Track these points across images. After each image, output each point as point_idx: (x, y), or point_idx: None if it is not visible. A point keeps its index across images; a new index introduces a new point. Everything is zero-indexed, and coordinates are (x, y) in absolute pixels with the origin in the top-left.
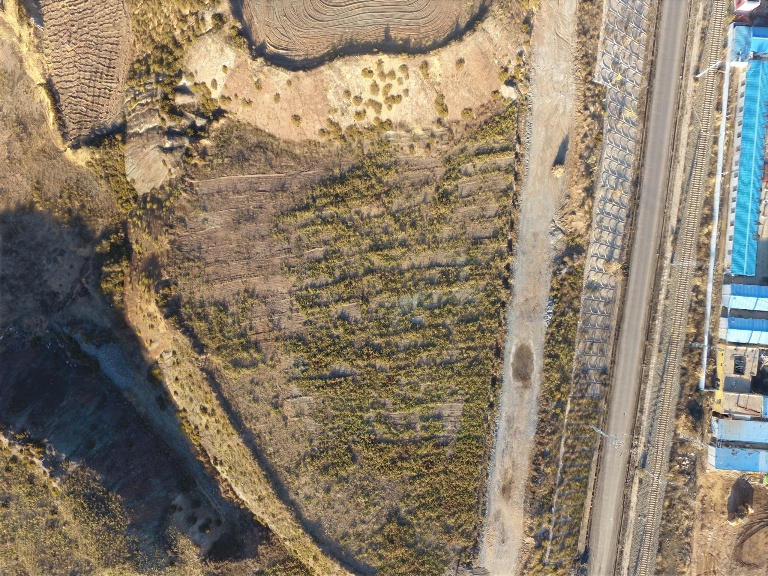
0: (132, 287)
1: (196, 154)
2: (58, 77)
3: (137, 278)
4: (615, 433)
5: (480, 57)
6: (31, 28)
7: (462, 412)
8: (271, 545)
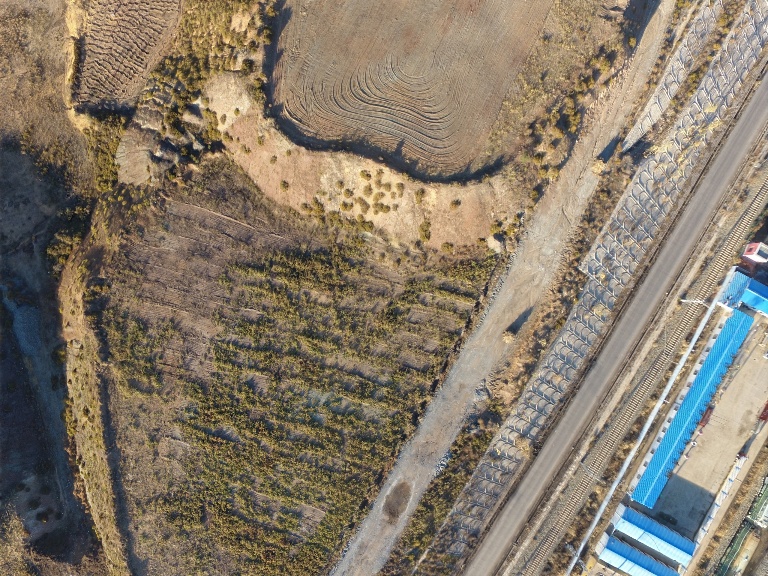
0: (73, 266)
1: (180, 175)
2: (92, 39)
3: (80, 261)
4: None
5: (477, 206)
6: None
7: (322, 520)
8: (96, 560)
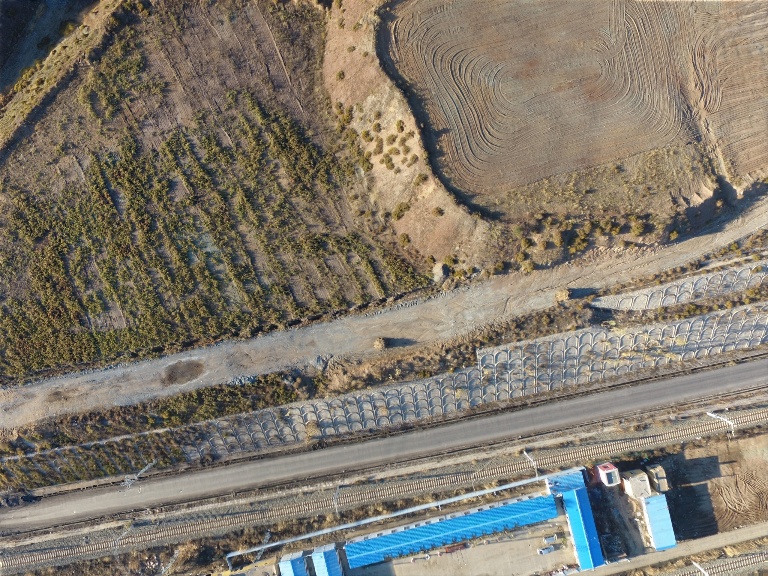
0: None
1: None
2: None
3: None
4: (160, 488)
5: (452, 229)
6: None
7: (118, 329)
8: None
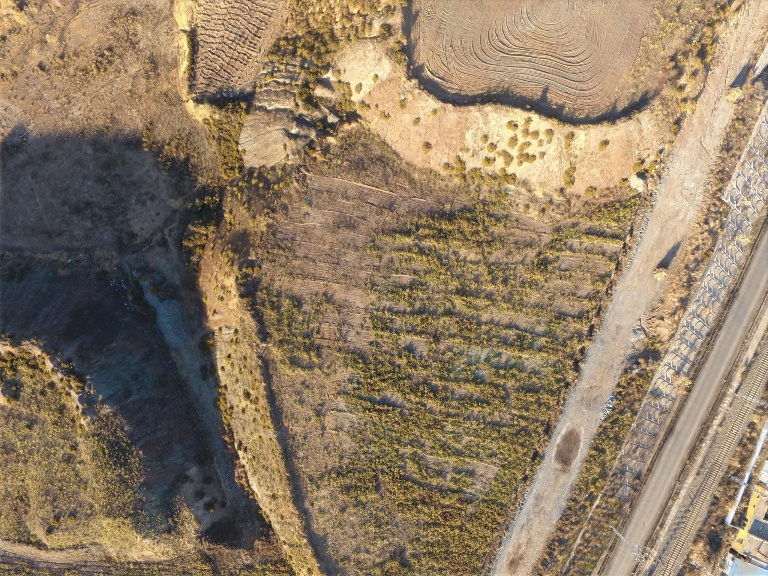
0: (213, 254)
1: (319, 149)
2: (203, 29)
3: (221, 247)
4: (630, 539)
5: (625, 144)
6: None
7: (495, 476)
8: (269, 543)
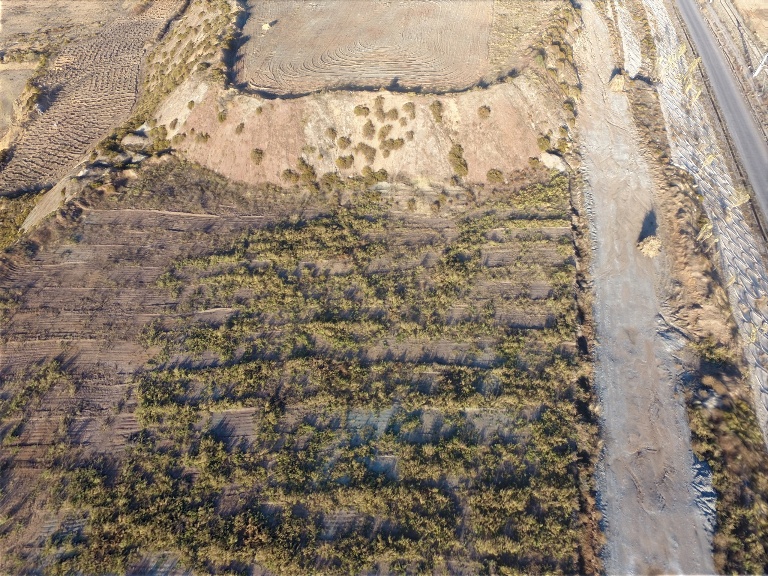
0: None
1: (109, 181)
2: (24, 145)
3: None
4: None
5: (511, 111)
6: (31, 111)
7: None
8: None
